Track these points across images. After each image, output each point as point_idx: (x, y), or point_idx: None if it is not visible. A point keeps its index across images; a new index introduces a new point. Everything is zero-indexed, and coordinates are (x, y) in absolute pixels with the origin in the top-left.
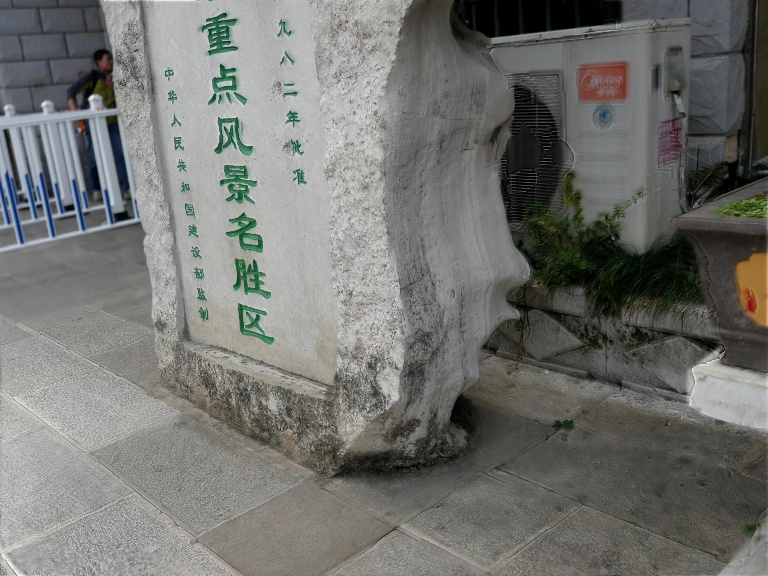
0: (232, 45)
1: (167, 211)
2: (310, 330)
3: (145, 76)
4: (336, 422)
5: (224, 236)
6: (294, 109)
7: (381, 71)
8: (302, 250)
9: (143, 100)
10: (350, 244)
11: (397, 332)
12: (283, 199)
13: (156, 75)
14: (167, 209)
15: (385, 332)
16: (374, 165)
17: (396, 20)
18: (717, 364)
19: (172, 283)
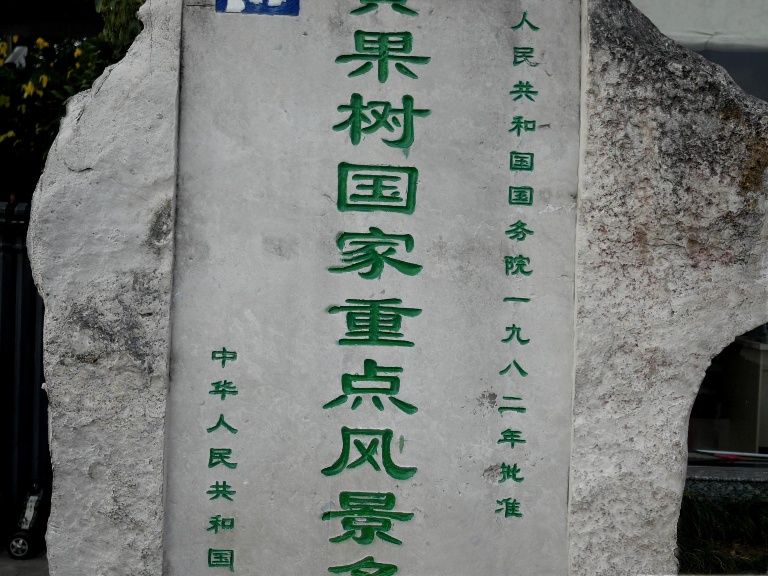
0: (405, 339)
1: (159, 564)
2: None
3: (163, 355)
4: None
5: None
6: (517, 427)
7: (681, 400)
8: None
9: (143, 389)
10: None
11: None
12: (468, 536)
13: (182, 354)
14: (160, 560)
15: None
16: (669, 498)
17: (709, 354)
18: None
19: None
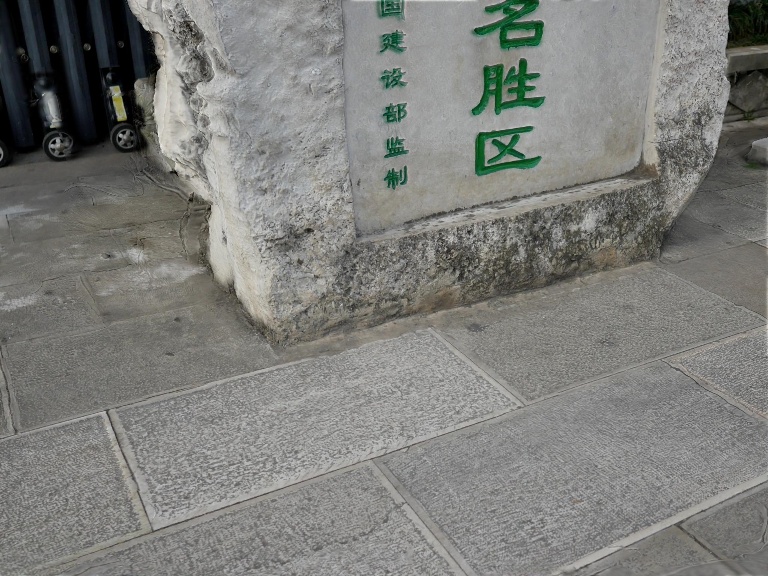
0: None
1: (340, 14)
2: (601, 122)
3: None
4: (666, 196)
5: (469, 36)
6: None
7: None
8: (606, 26)
9: None
10: (688, 2)
11: (725, 78)
12: None
13: None
14: (340, 10)
15: (712, 83)
16: None
17: None
18: None
19: (339, 147)
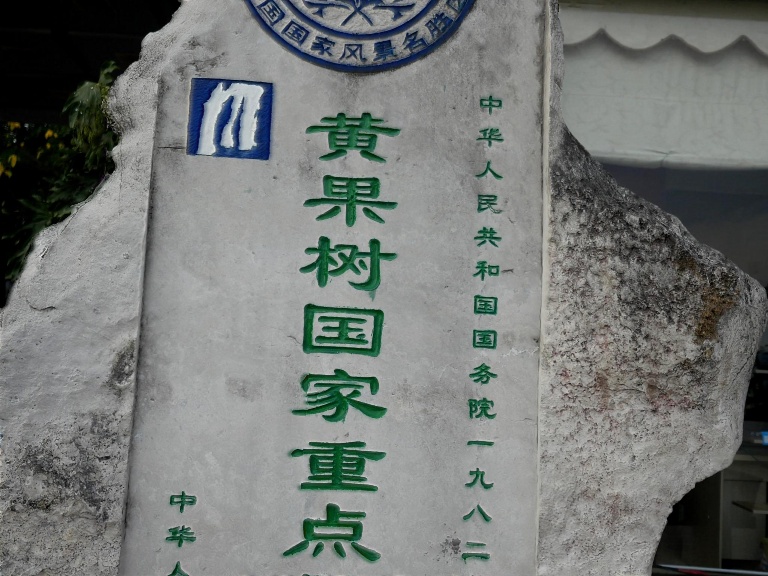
0: (369, 483)
1: None
2: None
3: (120, 500)
4: None
5: None
6: (481, 574)
7: (643, 546)
8: None
9: (97, 536)
10: None
11: None
12: None
13: (140, 498)
14: None
15: None
16: None
17: (670, 499)
18: None
19: None
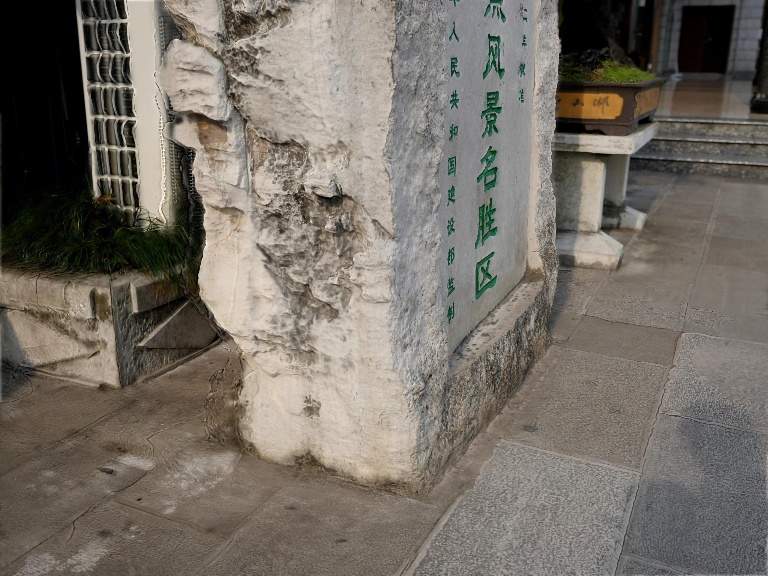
0: None
1: None
2: None
3: None
4: None
5: None
6: None
7: None
8: (515, 167)
9: None
10: None
11: None
12: None
13: None
14: None
15: (551, 201)
16: None
17: None
18: (627, 136)
19: None
